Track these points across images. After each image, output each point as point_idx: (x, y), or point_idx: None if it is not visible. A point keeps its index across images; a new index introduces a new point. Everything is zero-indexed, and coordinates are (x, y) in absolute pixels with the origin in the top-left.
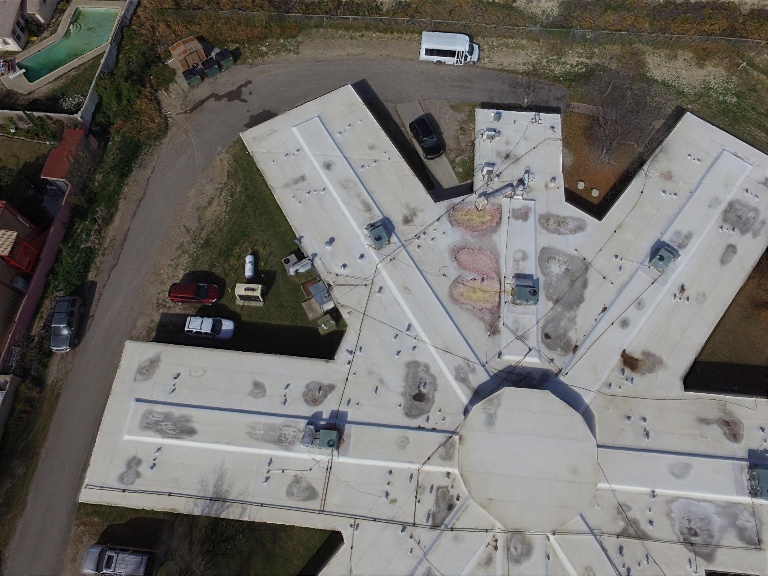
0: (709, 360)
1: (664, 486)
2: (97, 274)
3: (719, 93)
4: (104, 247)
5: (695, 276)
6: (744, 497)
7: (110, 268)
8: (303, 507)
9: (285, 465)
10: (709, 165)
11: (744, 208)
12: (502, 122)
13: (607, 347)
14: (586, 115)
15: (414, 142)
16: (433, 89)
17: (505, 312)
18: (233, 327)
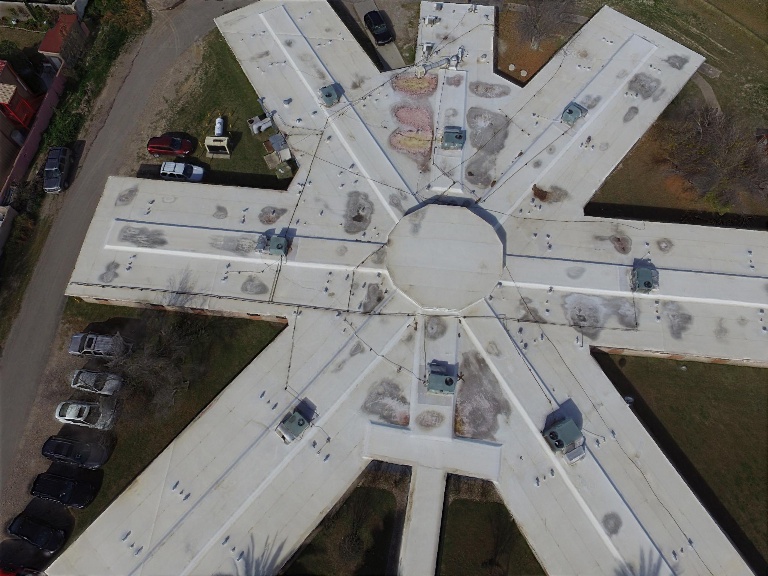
0: (612, 202)
1: (560, 283)
2: (86, 135)
3: None
4: (92, 114)
5: (600, 130)
6: (626, 292)
7: (97, 130)
8: (255, 299)
9: (241, 268)
10: (620, 46)
11: (647, 79)
12: (443, 11)
13: (520, 182)
14: (520, 13)
15: (368, 33)
16: None
17: (435, 155)
18: (202, 172)
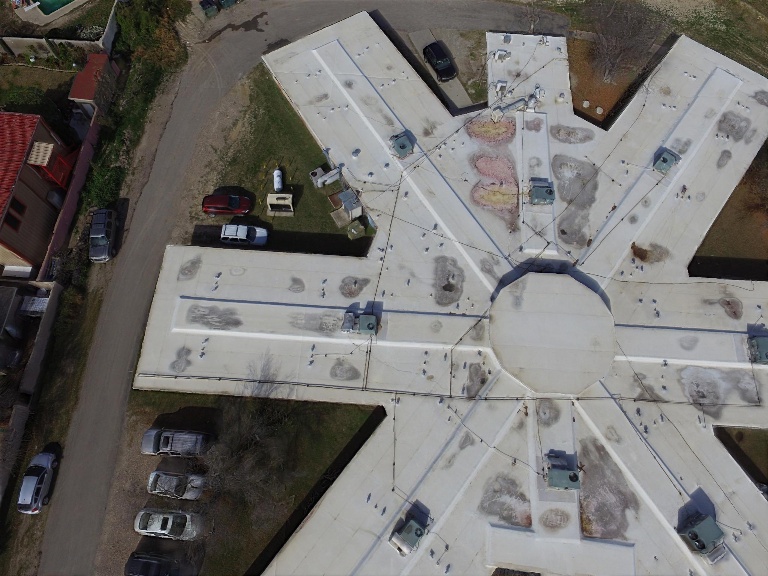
0: (708, 255)
1: (674, 356)
2: (128, 192)
3: (709, 21)
4: (133, 167)
5: (695, 178)
6: (745, 363)
7: (141, 186)
8: (347, 386)
9: (327, 350)
10: (704, 81)
11: (737, 118)
12: (512, 44)
13: (618, 240)
14: (588, 42)
15: (428, 67)
16: (443, 19)
17: (524, 211)
18: (267, 234)
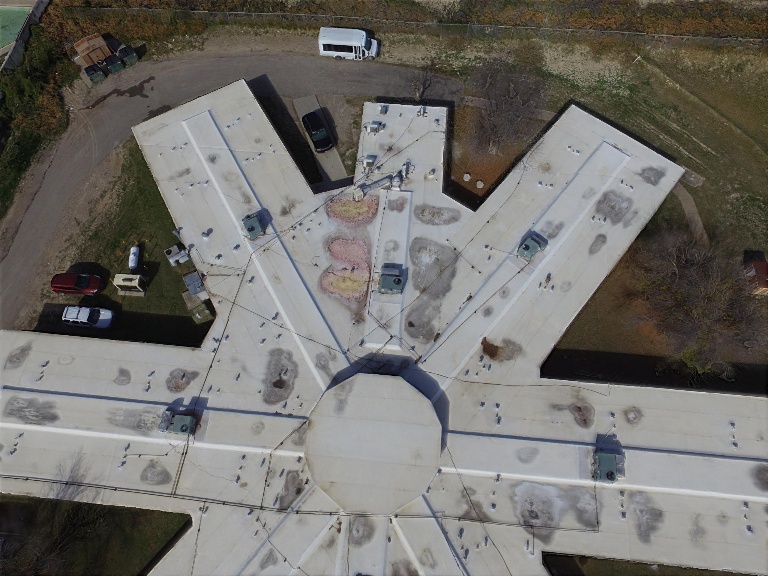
0: (576, 348)
1: (509, 470)
2: None
3: (612, 86)
4: None
5: (562, 265)
6: (587, 481)
7: None
8: (155, 491)
9: (142, 450)
10: (588, 156)
11: (618, 198)
12: (388, 115)
13: (468, 335)
14: (479, 108)
15: (307, 136)
16: (331, 84)
17: (371, 301)
18: (111, 317)
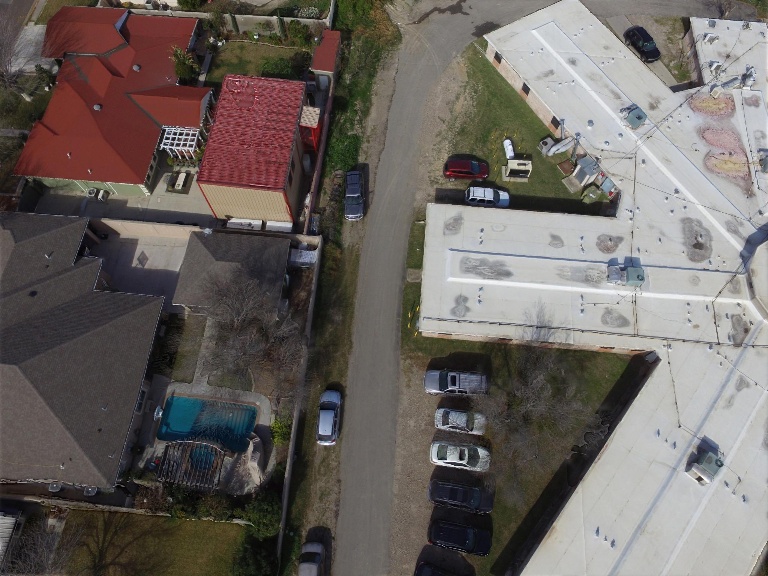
0: None
1: None
2: (367, 157)
3: None
4: (367, 135)
5: None
6: None
7: (378, 152)
8: (619, 332)
9: (596, 299)
10: None
11: None
12: (717, 28)
13: None
14: None
15: None
16: (636, 6)
17: (758, 179)
18: (509, 197)
